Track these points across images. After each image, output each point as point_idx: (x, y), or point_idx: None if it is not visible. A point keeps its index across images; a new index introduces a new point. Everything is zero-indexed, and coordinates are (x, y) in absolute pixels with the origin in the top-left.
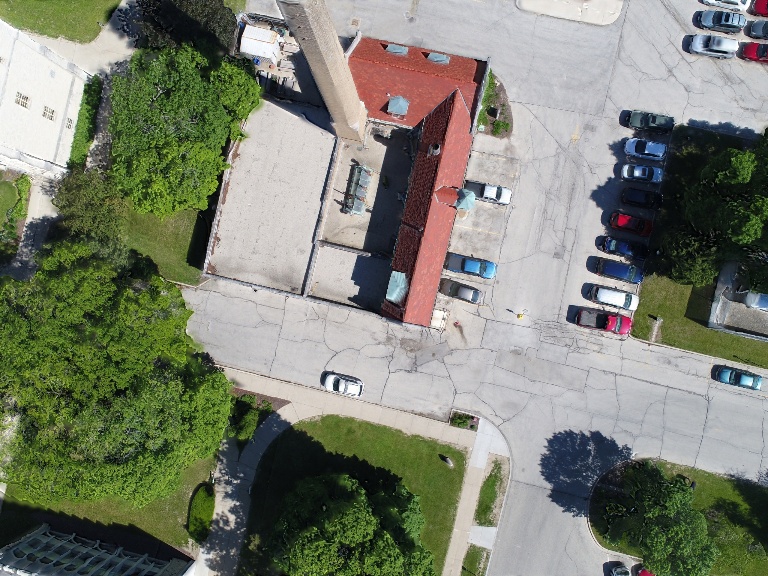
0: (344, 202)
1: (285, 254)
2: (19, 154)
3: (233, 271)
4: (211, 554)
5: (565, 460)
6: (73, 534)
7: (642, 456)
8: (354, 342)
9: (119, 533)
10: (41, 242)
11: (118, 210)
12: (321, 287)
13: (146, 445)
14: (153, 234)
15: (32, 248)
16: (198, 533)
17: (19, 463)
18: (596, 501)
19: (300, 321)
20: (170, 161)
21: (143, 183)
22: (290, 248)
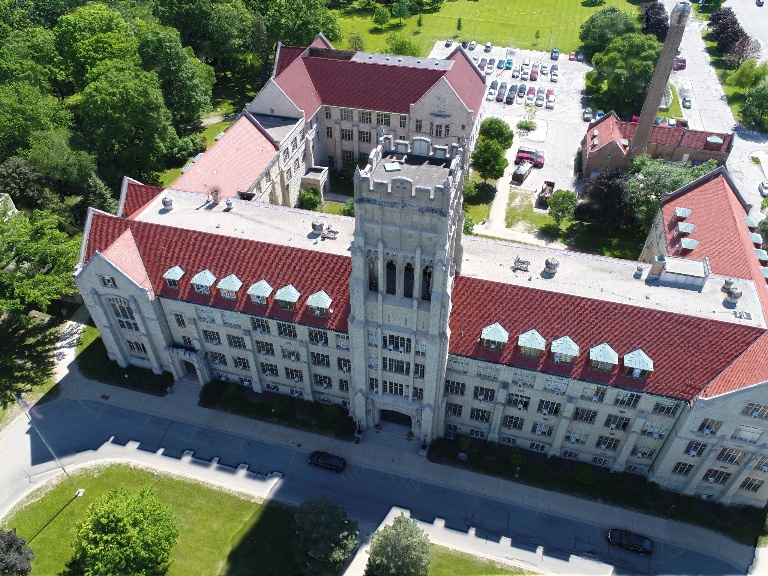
0: None
1: None
2: None
3: None
4: None
5: (753, 138)
6: None
7: (736, 122)
8: (739, 188)
9: None
10: None
11: None
12: None
13: None
14: None
15: None
16: None
17: None
18: (766, 131)
19: None
20: None
21: None
22: None
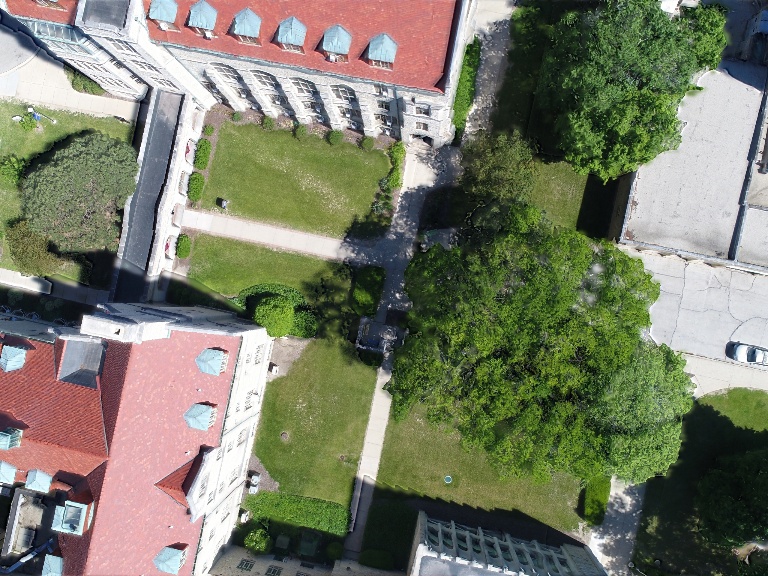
0: (764, 162)
1: (709, 217)
2: (454, 113)
3: (652, 236)
4: (605, 539)
5: None
6: (451, 521)
7: None
8: (761, 310)
9: (503, 519)
10: (417, 213)
11: (534, 174)
12: (745, 251)
13: (666, 415)
14: (539, 202)
15: (407, 219)
16: (595, 516)
17: (538, 437)
18: None
19: (701, 290)
20: (663, 113)
21: (606, 140)
22: (715, 211)
